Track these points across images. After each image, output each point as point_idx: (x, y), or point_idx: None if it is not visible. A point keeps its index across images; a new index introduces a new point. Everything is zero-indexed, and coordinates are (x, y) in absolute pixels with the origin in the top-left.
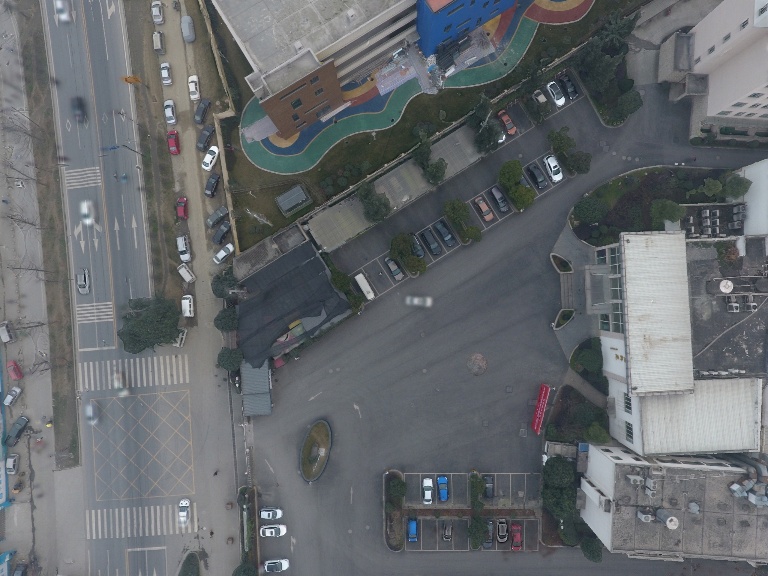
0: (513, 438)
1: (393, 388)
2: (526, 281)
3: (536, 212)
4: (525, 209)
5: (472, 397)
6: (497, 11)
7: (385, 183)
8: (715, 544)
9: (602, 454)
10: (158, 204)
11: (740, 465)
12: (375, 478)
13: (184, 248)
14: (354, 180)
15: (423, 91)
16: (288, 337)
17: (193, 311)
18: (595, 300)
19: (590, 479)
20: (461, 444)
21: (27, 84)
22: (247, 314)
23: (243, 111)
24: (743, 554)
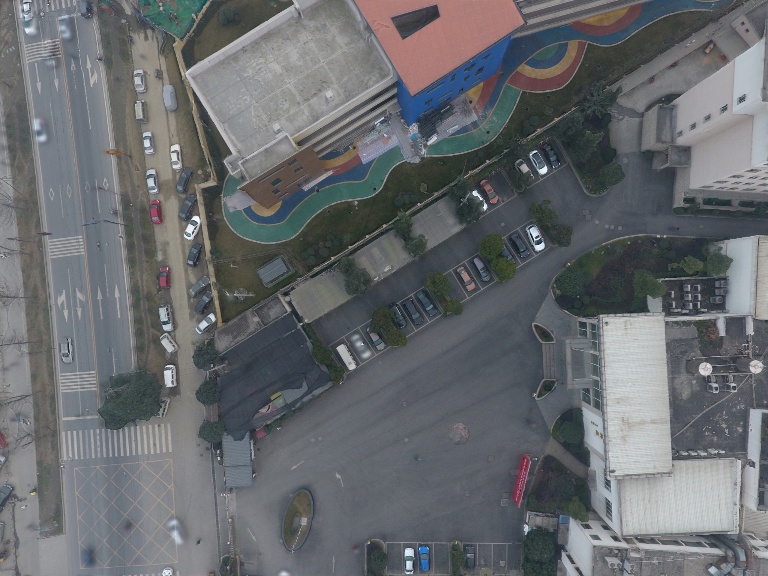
0: (495, 507)
1: (375, 457)
2: (508, 350)
3: (518, 281)
4: None
5: (454, 466)
6: (479, 80)
7: (366, 254)
8: None
9: (581, 531)
10: (141, 273)
11: (719, 546)
12: (357, 547)
13: (166, 319)
14: (336, 250)
15: (405, 160)
16: (270, 408)
17: (176, 381)
18: (576, 375)
19: (570, 553)
20: (443, 513)
21: (10, 152)
22: (229, 386)
23: (225, 180)
24: None
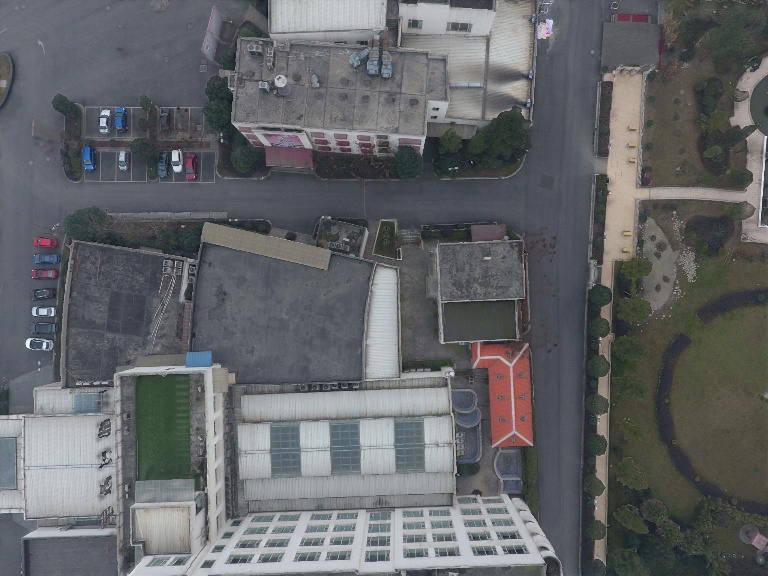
0: (193, 74)
1: (77, 25)
2: None
3: None
4: None
5: (154, 34)
6: None
7: None
8: (337, 118)
9: None
10: None
11: None
12: (57, 111)
13: None
14: None
15: None
16: None
17: None
18: None
19: None
20: (142, 79)
21: None
22: None
23: None
24: (364, 128)
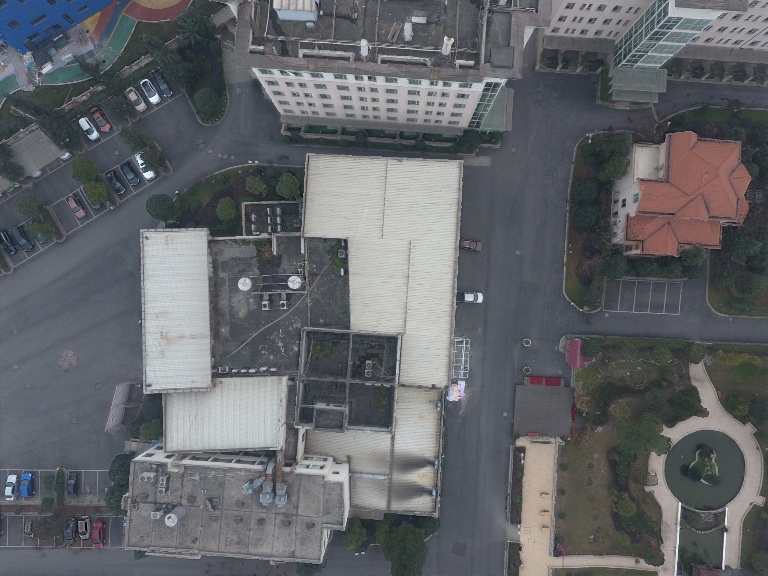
0: (101, 435)
1: None
2: (119, 278)
3: (131, 209)
4: (120, 206)
5: (62, 394)
6: (90, 8)
7: None
8: (232, 542)
9: None
10: None
11: None
12: None
13: None
14: None
15: (20, 88)
16: None
17: None
18: None
19: None
20: (50, 441)
21: None
22: None
23: None
24: (259, 552)
